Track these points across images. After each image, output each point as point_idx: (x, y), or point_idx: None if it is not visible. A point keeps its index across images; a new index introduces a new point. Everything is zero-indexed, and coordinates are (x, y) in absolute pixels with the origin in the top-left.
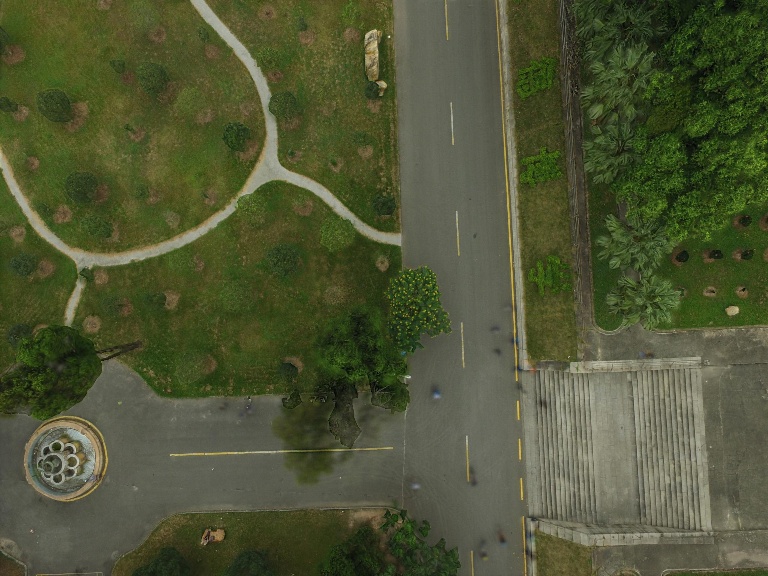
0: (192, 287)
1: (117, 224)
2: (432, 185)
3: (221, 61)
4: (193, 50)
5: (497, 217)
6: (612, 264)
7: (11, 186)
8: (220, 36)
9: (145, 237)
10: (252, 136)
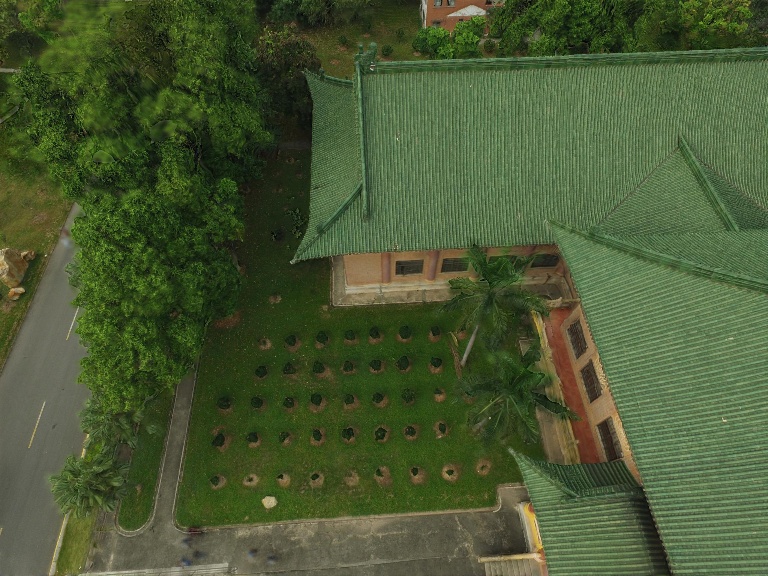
0: None
1: None
2: (31, 376)
3: None
4: None
5: (84, 407)
6: (83, 443)
7: None
8: None
9: None
10: None
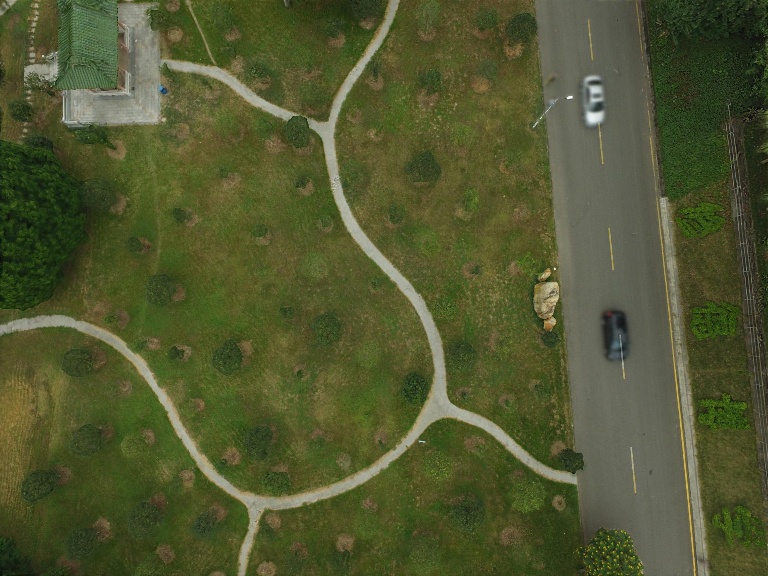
0: None
1: (287, 466)
2: (605, 421)
3: (385, 296)
4: (356, 286)
5: (672, 452)
6: None
7: (177, 429)
8: (383, 271)
9: (316, 479)
10: (420, 373)
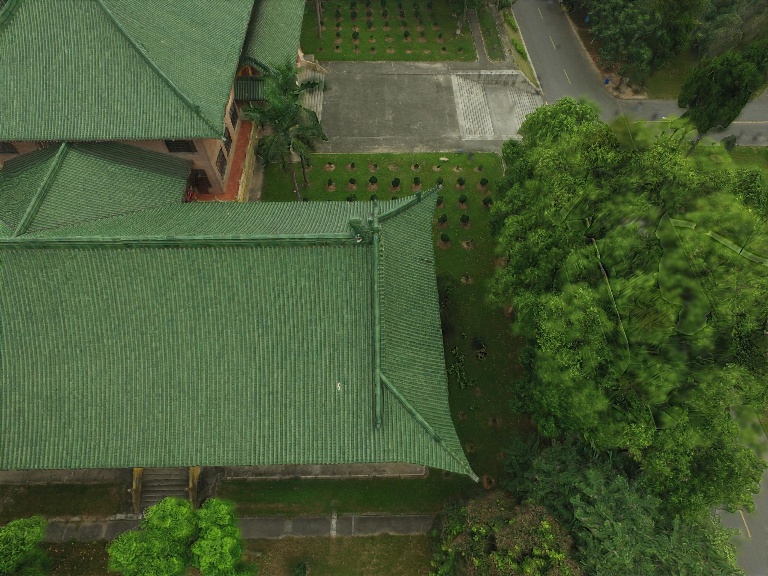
0: None
1: None
2: None
3: None
4: None
5: None
6: None
7: None
8: None
9: None
10: None
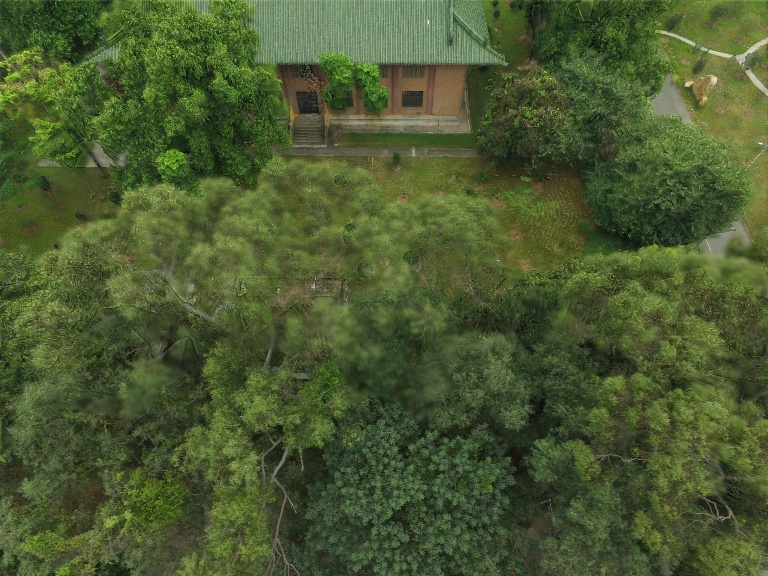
0: (762, 20)
1: None
2: None
3: None
4: None
5: None
6: None
7: None
8: None
9: None
10: (761, 72)
